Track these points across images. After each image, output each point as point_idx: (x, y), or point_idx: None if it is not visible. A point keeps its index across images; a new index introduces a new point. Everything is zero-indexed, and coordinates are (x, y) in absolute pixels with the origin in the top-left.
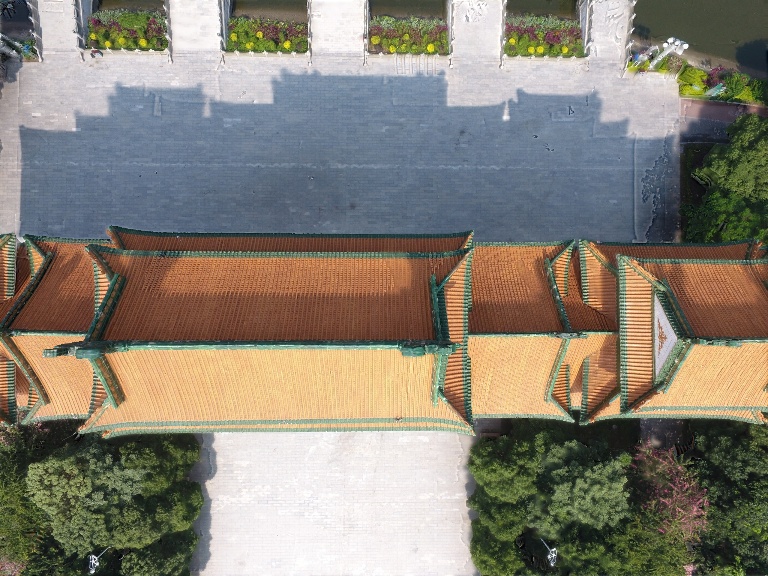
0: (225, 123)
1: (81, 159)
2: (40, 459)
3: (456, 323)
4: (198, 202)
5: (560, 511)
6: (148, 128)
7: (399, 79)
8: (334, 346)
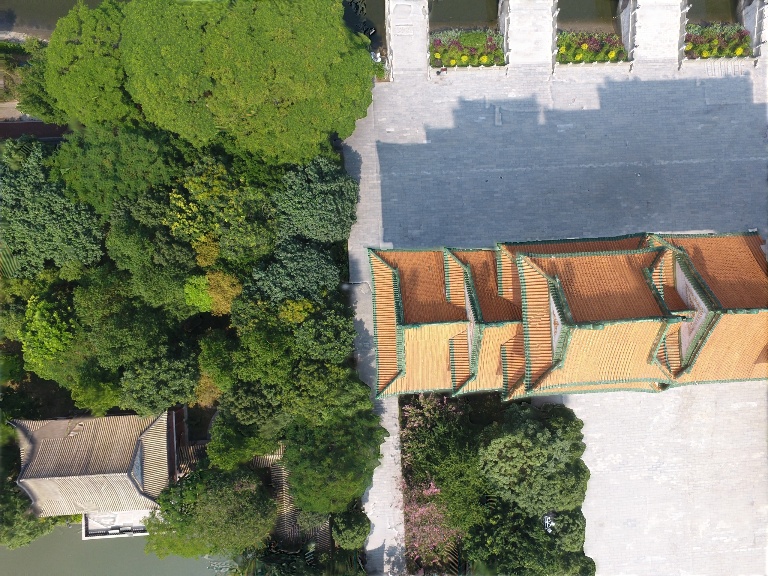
0: (559, 129)
1: (433, 168)
2: (466, 438)
3: None
4: (540, 202)
5: None
6: (491, 137)
7: (710, 81)
8: None
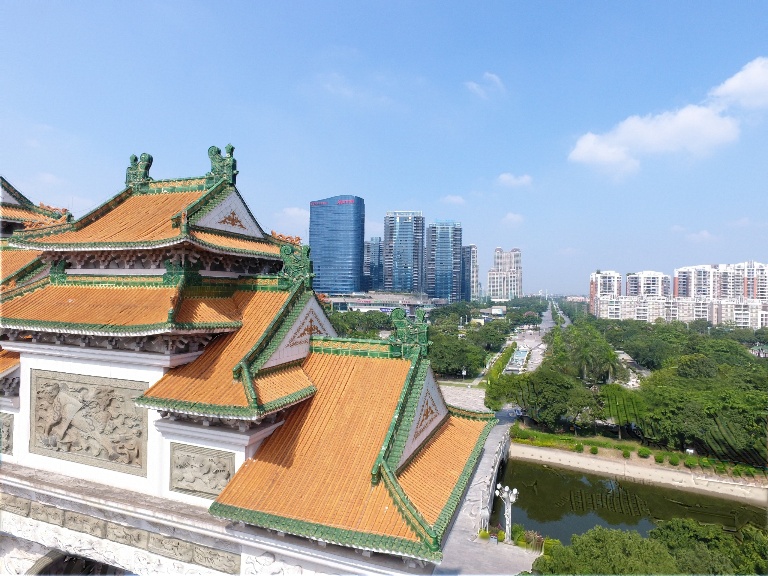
0: None
1: None
2: None
3: (4, 213)
4: None
5: None
6: None
7: None
8: None
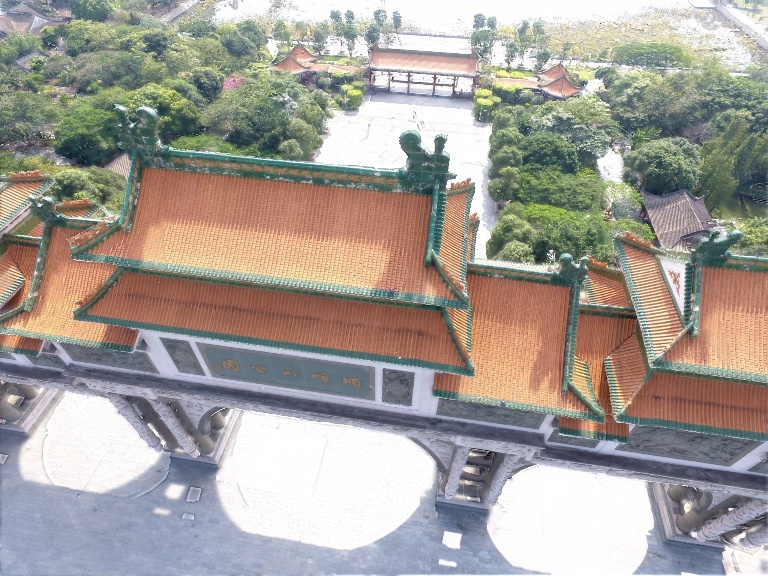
0: None
1: None
2: None
3: None
4: None
5: None
6: None
7: None
8: None
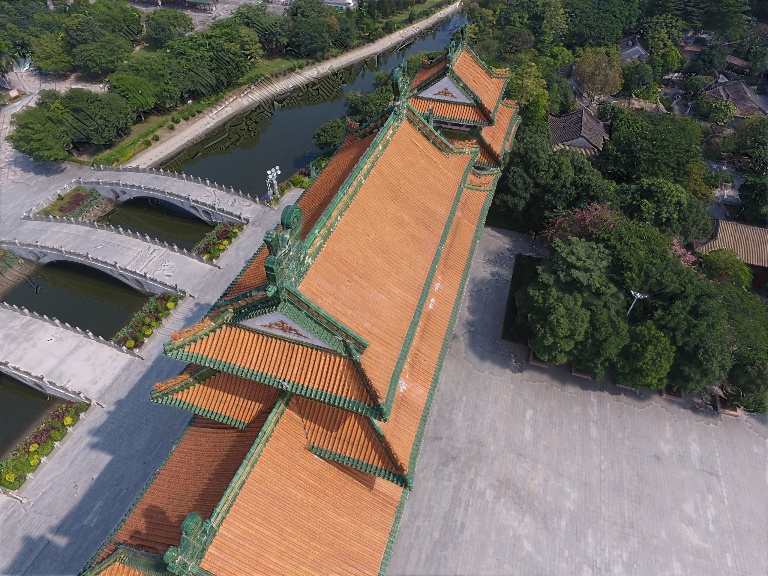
0: (89, 524)
1: None
2: None
3: None
4: None
5: (596, 281)
6: None
7: None
8: (377, 134)
